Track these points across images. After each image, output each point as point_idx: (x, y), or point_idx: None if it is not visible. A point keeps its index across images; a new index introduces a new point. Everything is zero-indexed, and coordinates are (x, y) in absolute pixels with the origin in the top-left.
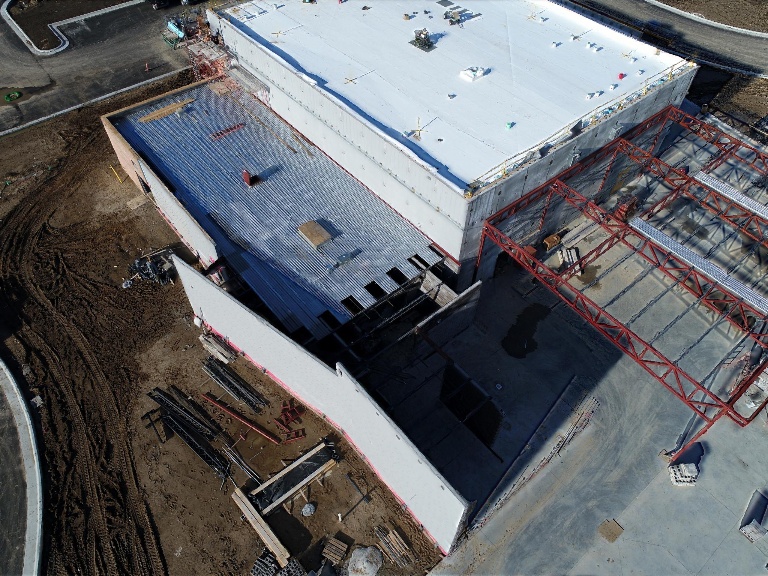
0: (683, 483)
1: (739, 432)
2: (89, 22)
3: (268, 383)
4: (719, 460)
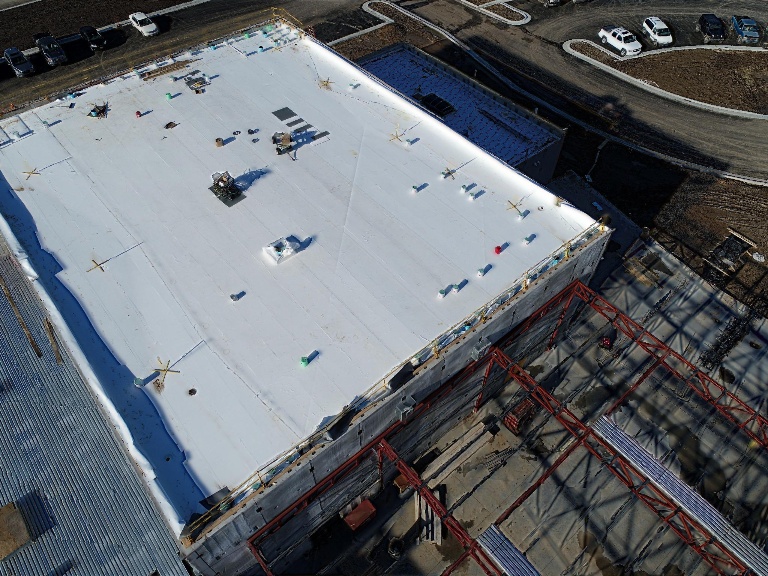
0: None
1: None
2: None
3: None
4: None
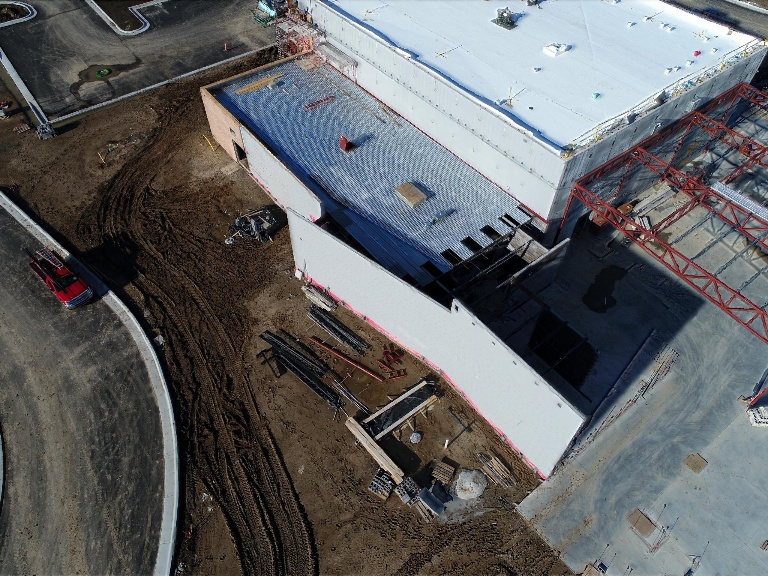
0: (762, 424)
1: None
2: (166, 5)
3: (368, 329)
4: None
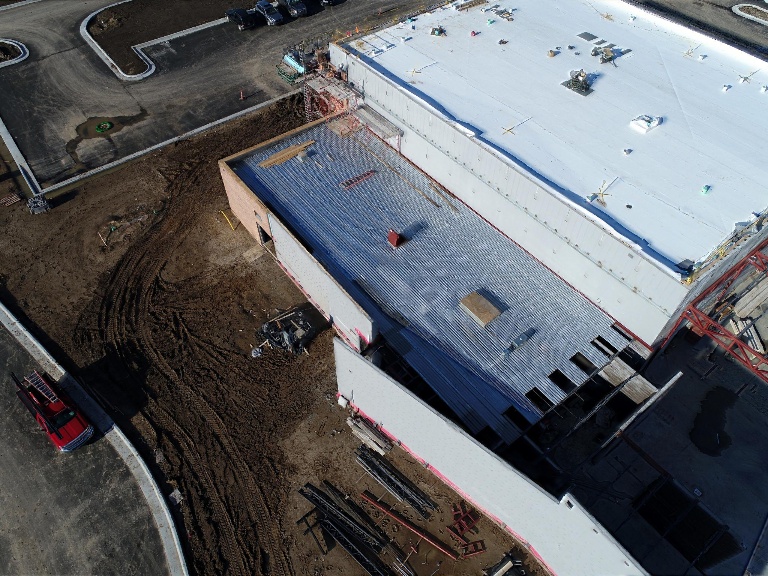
0: None
1: None
2: (174, 44)
3: (432, 481)
4: None
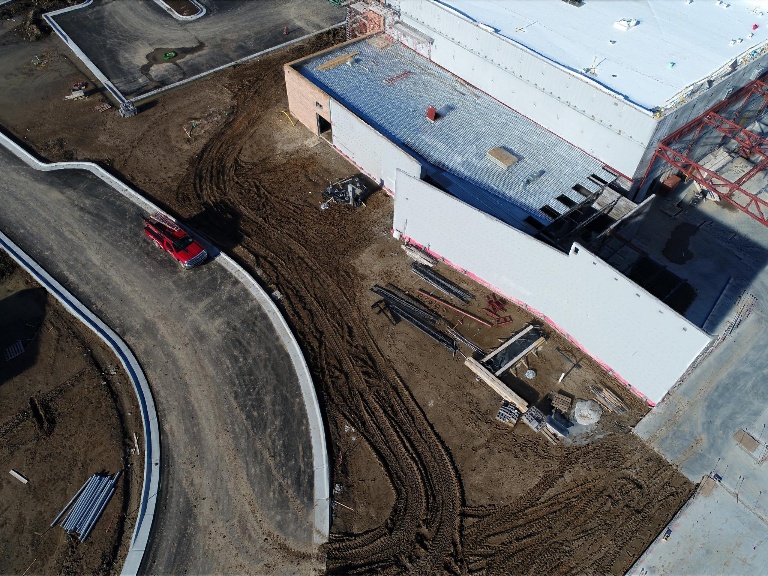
0: None
1: None
2: None
3: (470, 282)
4: None
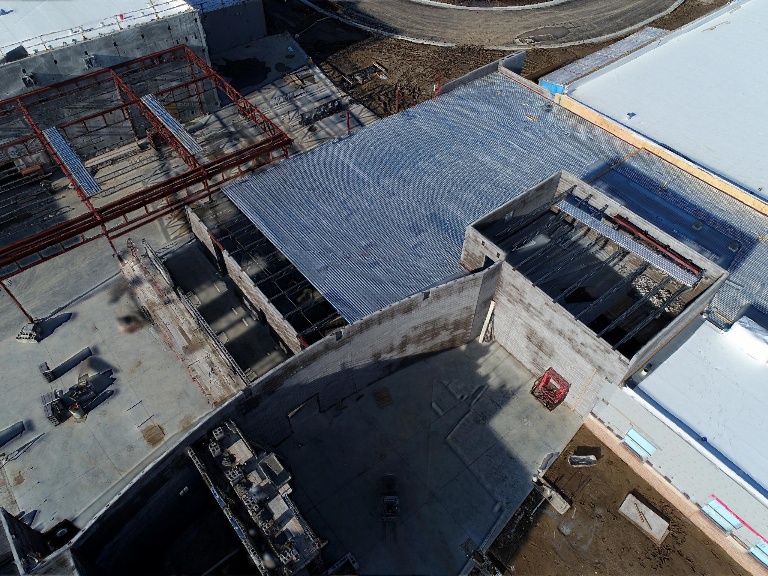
0: (22, 339)
1: (112, 306)
2: None
3: None
4: (76, 326)
